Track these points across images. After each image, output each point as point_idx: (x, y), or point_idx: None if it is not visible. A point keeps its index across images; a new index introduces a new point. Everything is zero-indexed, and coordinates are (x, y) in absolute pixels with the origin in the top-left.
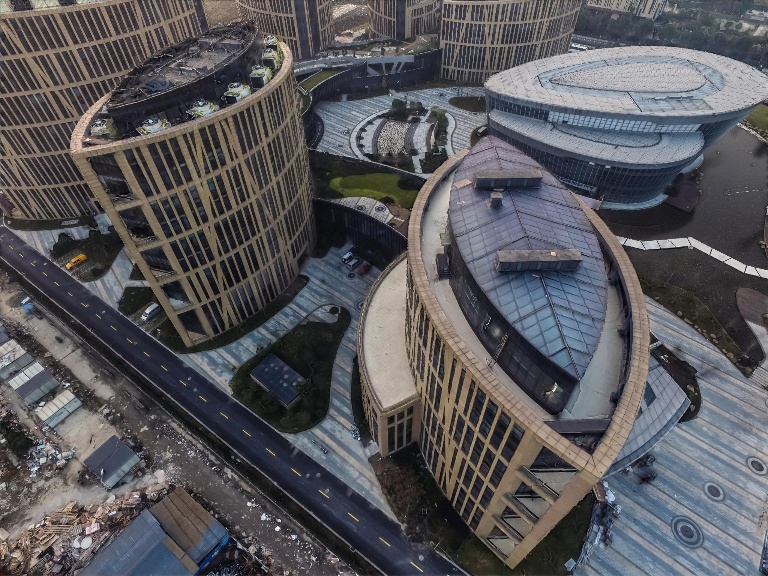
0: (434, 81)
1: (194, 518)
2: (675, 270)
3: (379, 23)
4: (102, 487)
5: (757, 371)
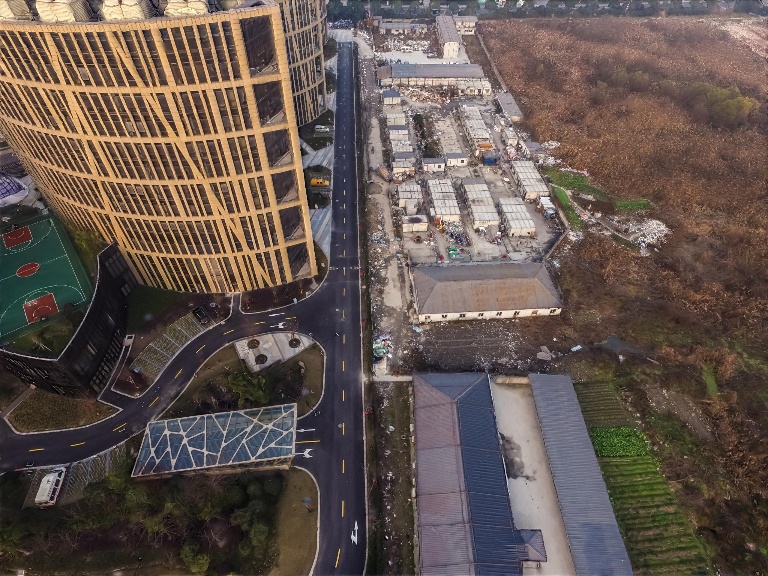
0: None
1: (382, 72)
2: None
3: None
4: (401, 99)
5: None
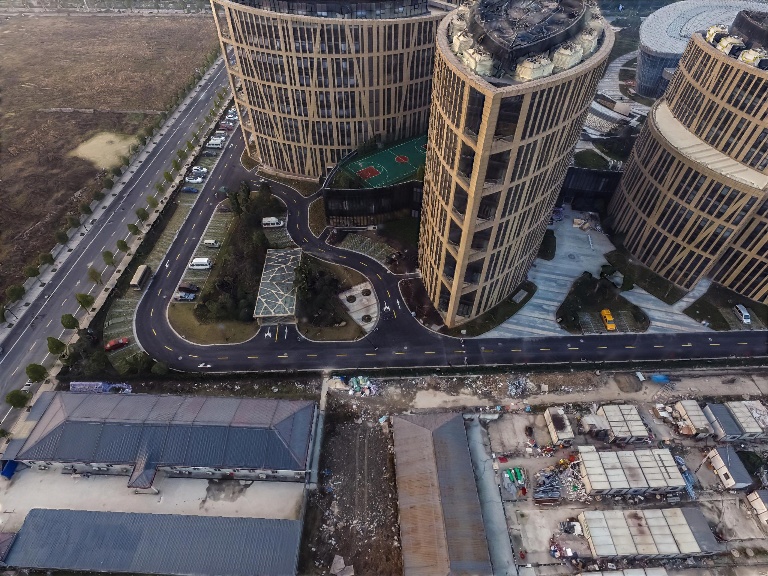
0: None
1: None
2: None
3: None
4: None
5: None
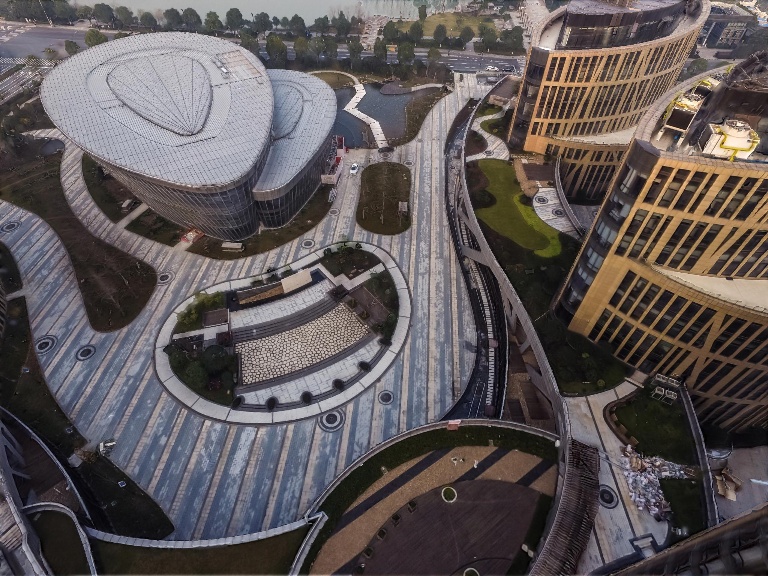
0: (4, 395)
1: None
2: (388, 112)
3: None
4: None
5: (447, 88)
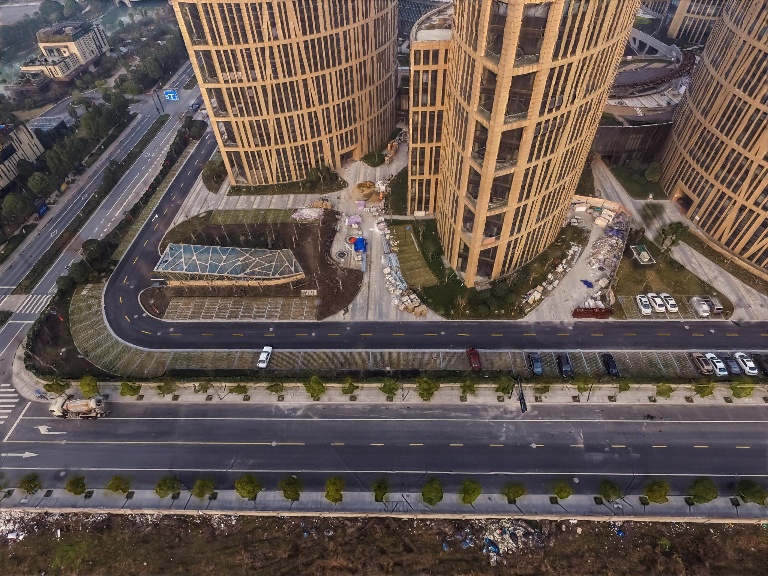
0: None
1: None
2: None
3: (389, 87)
4: None
5: None
